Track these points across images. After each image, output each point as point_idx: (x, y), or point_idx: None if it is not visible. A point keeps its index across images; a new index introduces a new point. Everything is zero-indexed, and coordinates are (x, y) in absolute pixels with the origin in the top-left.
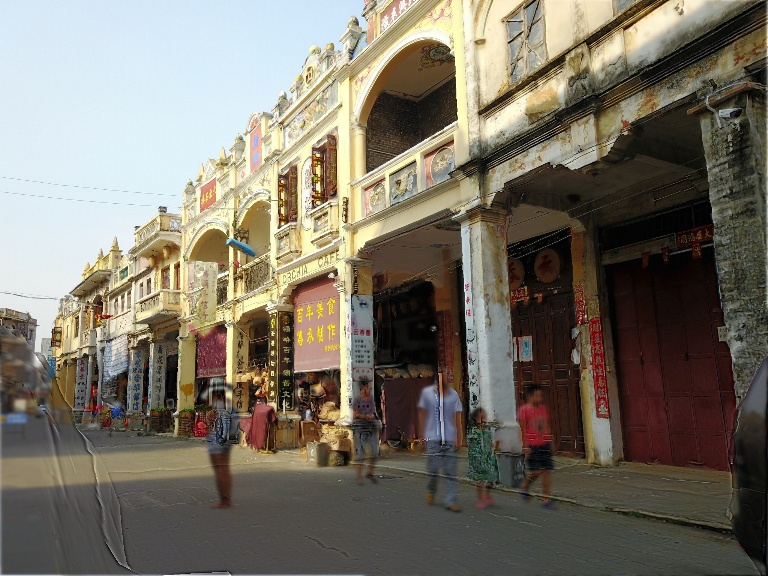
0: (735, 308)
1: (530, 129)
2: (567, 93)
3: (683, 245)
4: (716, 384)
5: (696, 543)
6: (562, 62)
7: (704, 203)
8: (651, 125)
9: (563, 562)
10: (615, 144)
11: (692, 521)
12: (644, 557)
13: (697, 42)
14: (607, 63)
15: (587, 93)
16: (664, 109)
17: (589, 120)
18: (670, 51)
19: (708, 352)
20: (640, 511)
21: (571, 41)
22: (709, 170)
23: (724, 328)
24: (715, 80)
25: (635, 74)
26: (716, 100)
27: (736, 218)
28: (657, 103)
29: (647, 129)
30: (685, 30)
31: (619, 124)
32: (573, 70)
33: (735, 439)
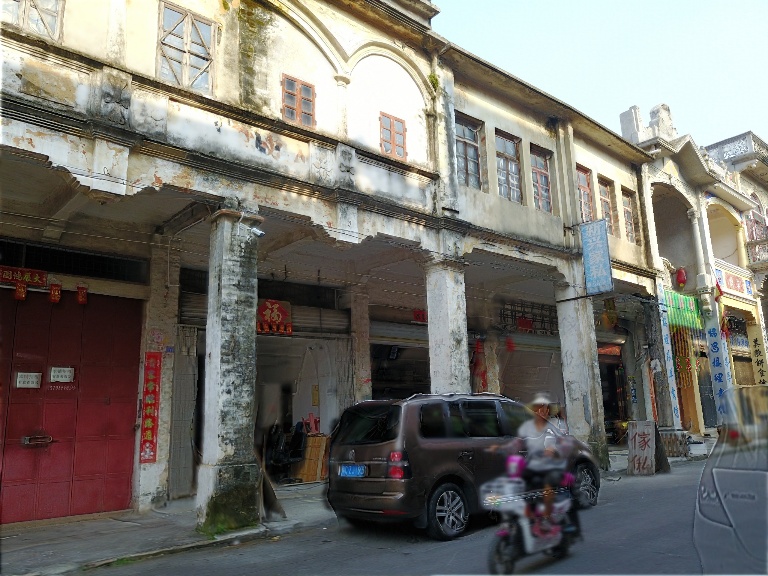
0: (230, 369)
1: (23, 98)
2: (94, 102)
3: (5, 280)
4: (2, 432)
5: (243, 551)
6: (94, 67)
7: (40, 248)
8: (165, 192)
9: (311, 572)
10: (142, 190)
11: (185, 546)
12: (293, 558)
13: (240, 166)
14: (149, 113)
15: (126, 124)
16: (192, 191)
17: (123, 151)
18: (206, 151)
19: (1, 397)
20: (131, 555)
21: (102, 53)
22: (226, 260)
23: (26, 374)
24: (240, 199)
25: (188, 150)
26: (244, 216)
27: (240, 304)
28: (193, 184)
29: (158, 192)
30: (220, 145)
31: (152, 176)
32: (113, 89)
33: (407, 452)
